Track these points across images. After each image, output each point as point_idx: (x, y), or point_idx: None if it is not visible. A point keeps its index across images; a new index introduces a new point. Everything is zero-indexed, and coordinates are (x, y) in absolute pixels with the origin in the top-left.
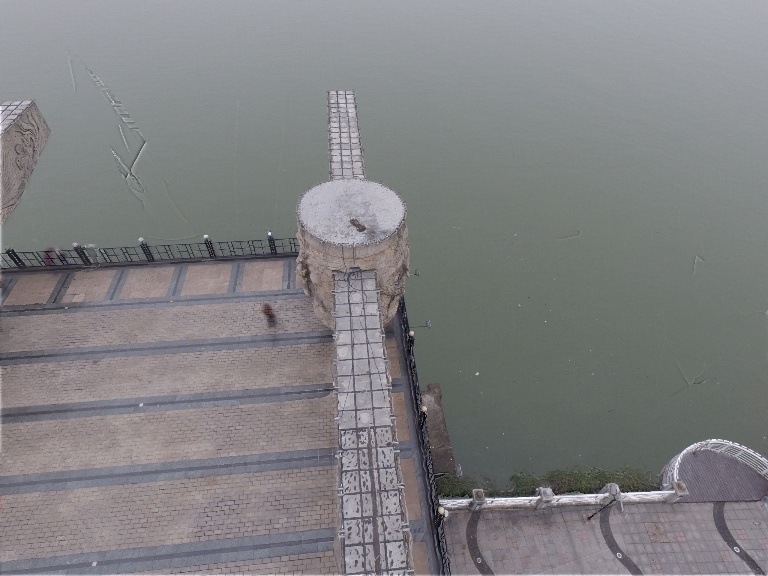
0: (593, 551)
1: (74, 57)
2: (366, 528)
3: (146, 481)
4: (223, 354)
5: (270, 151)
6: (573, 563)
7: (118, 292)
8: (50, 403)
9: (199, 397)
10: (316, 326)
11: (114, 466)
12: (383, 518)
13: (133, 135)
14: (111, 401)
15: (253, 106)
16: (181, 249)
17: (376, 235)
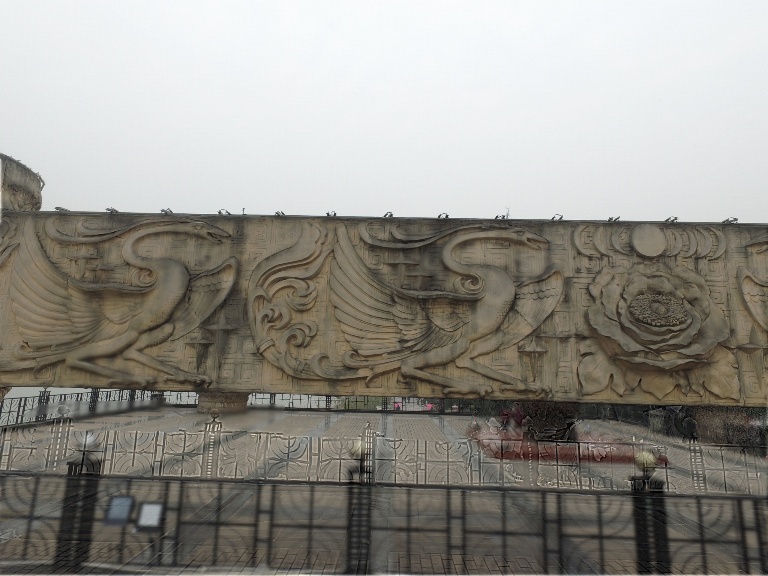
0: None
1: None
2: None
3: None
4: None
5: None
6: None
7: None
8: None
9: None
10: None
11: None
12: None
13: None
14: None
15: None
16: None
17: None
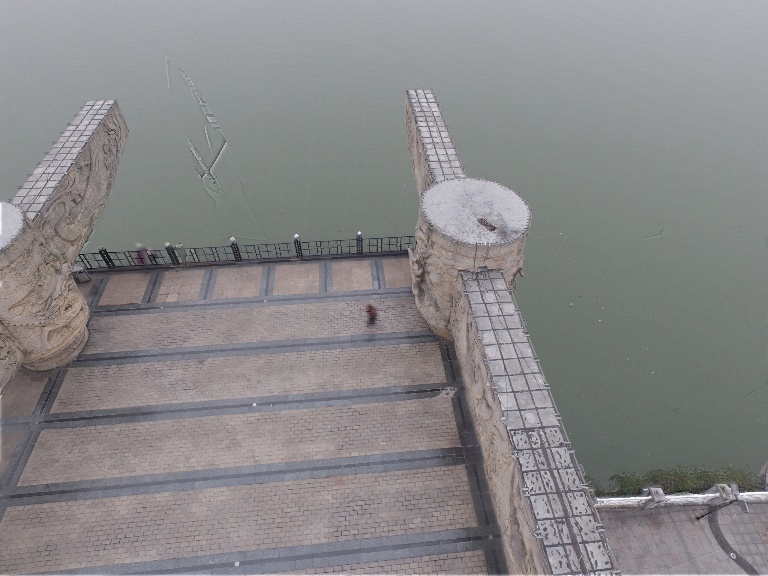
0: (706, 551)
1: (170, 57)
2: (561, 529)
3: (273, 481)
4: (327, 354)
5: (347, 150)
6: (688, 563)
7: (210, 292)
8: (163, 403)
9: (311, 397)
10: (414, 326)
11: (239, 466)
12: (575, 519)
13: (216, 135)
14: (224, 401)
15: (334, 105)
16: (270, 249)
17: (508, 235)
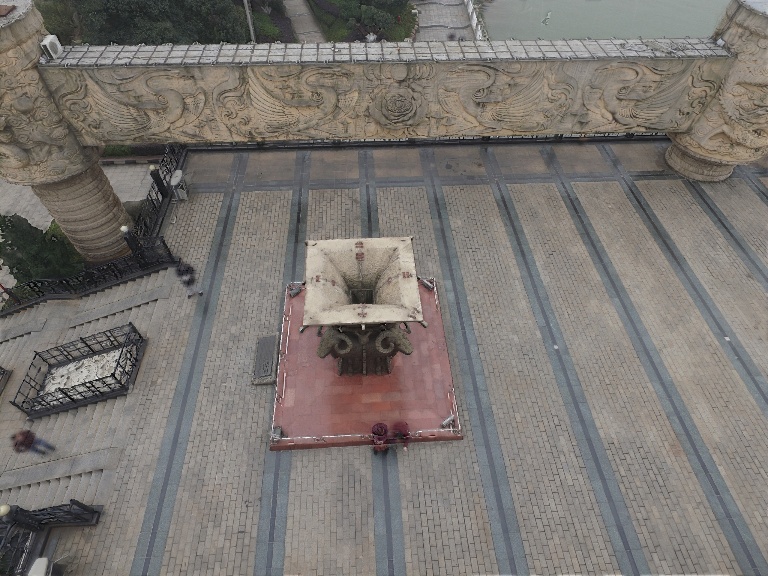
0: None
1: None
2: None
3: (647, 371)
4: None
5: None
6: None
7: None
8: (684, 254)
9: None
10: None
11: (649, 333)
12: None
13: None
14: (715, 307)
15: None
16: None
17: None
